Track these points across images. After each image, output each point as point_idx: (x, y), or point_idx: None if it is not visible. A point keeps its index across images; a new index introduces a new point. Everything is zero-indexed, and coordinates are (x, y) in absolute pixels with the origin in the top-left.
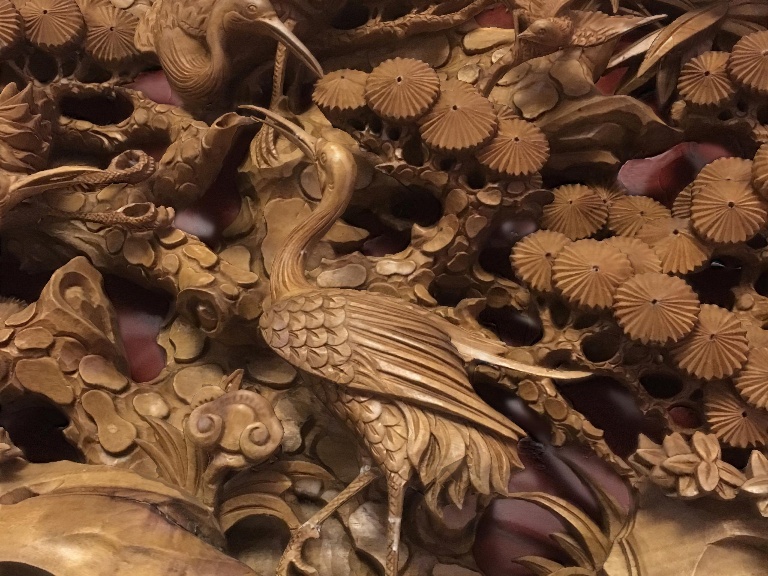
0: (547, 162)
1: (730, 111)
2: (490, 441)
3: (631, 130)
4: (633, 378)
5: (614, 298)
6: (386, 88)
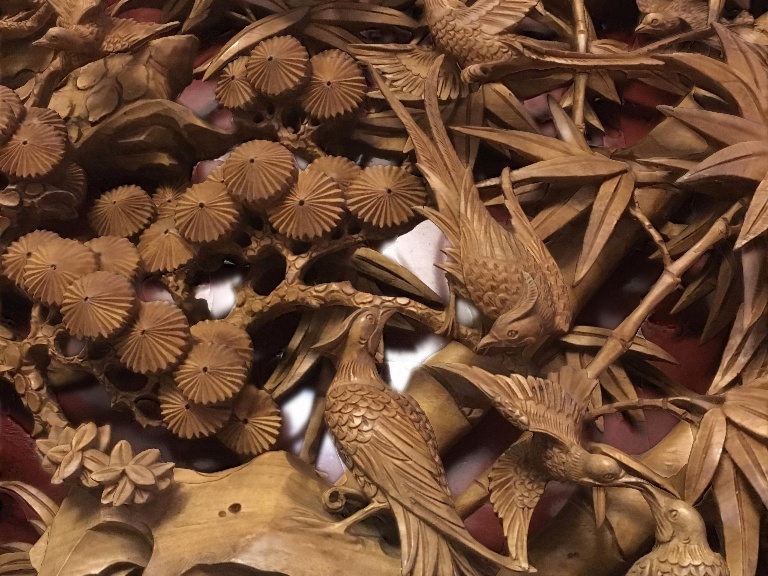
0: (117, 164)
1: (262, 114)
2: None
3: (179, 133)
4: (98, 372)
5: (62, 295)
6: None
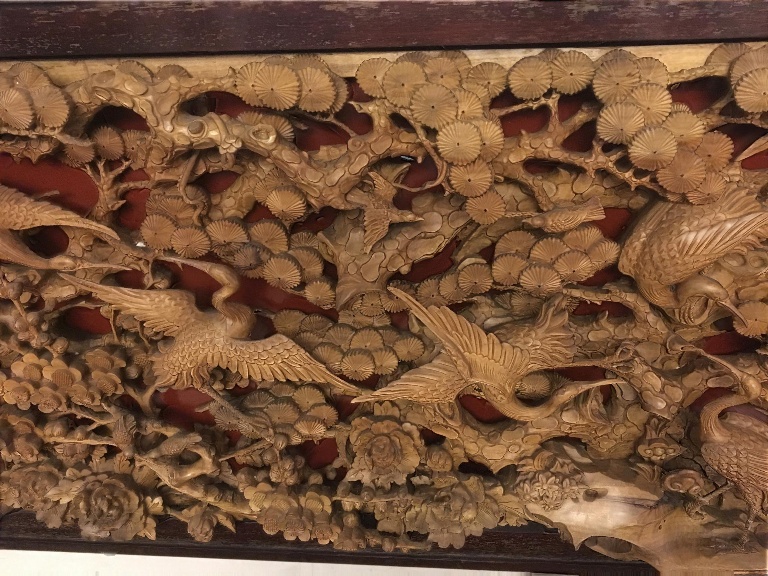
0: None
1: None
2: None
3: None
4: None
5: None
6: None
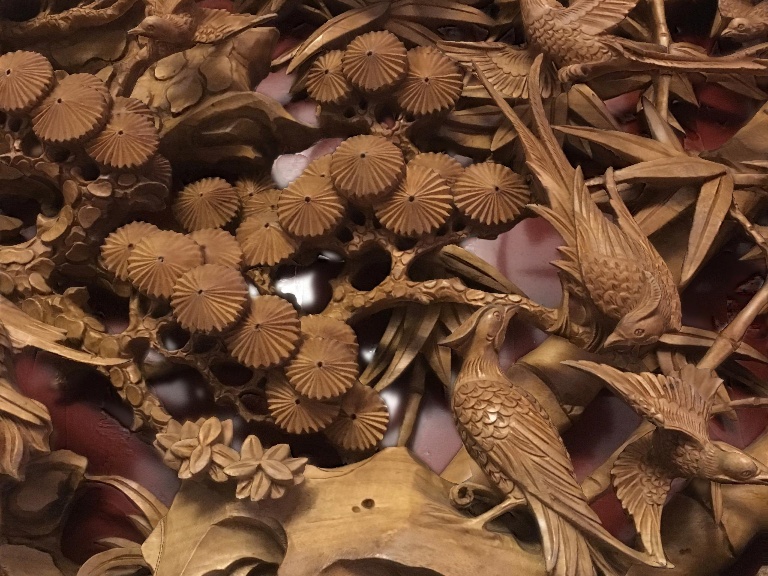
0: (198, 156)
1: (353, 109)
2: (9, 425)
3: (266, 126)
4: (203, 366)
5: (172, 288)
6: None
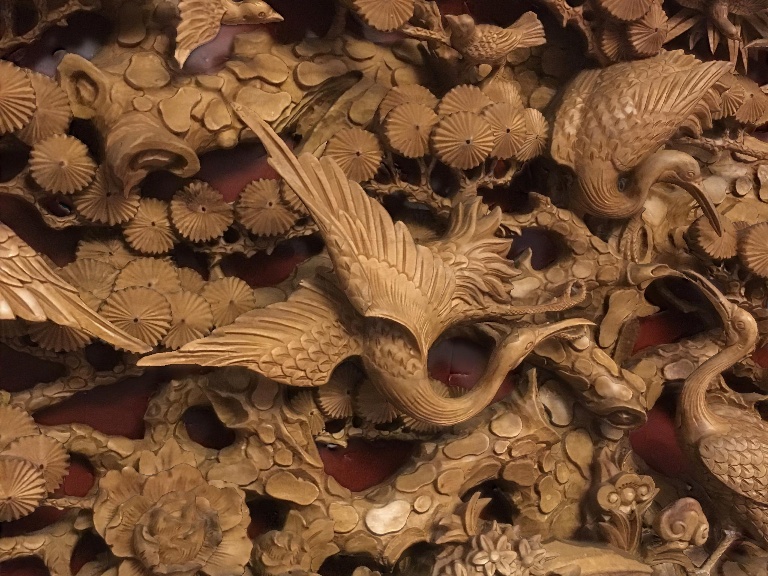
0: None
1: None
2: None
3: None
4: None
5: None
6: (764, 255)
